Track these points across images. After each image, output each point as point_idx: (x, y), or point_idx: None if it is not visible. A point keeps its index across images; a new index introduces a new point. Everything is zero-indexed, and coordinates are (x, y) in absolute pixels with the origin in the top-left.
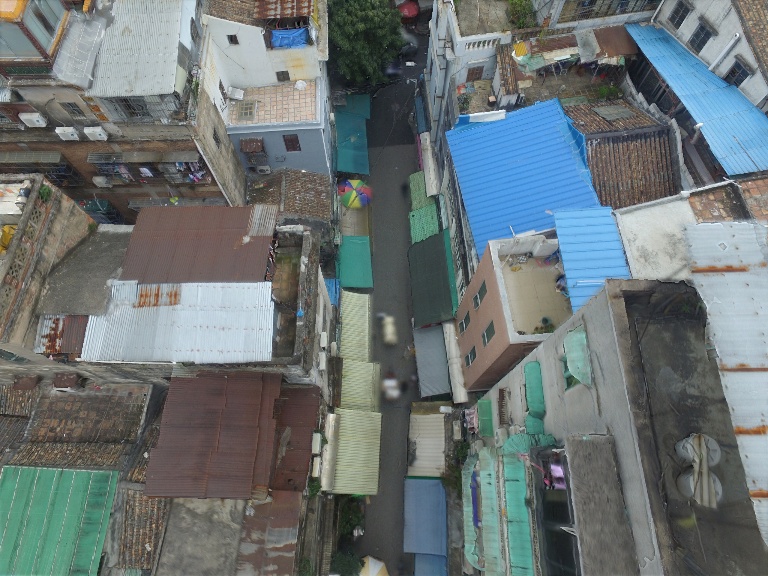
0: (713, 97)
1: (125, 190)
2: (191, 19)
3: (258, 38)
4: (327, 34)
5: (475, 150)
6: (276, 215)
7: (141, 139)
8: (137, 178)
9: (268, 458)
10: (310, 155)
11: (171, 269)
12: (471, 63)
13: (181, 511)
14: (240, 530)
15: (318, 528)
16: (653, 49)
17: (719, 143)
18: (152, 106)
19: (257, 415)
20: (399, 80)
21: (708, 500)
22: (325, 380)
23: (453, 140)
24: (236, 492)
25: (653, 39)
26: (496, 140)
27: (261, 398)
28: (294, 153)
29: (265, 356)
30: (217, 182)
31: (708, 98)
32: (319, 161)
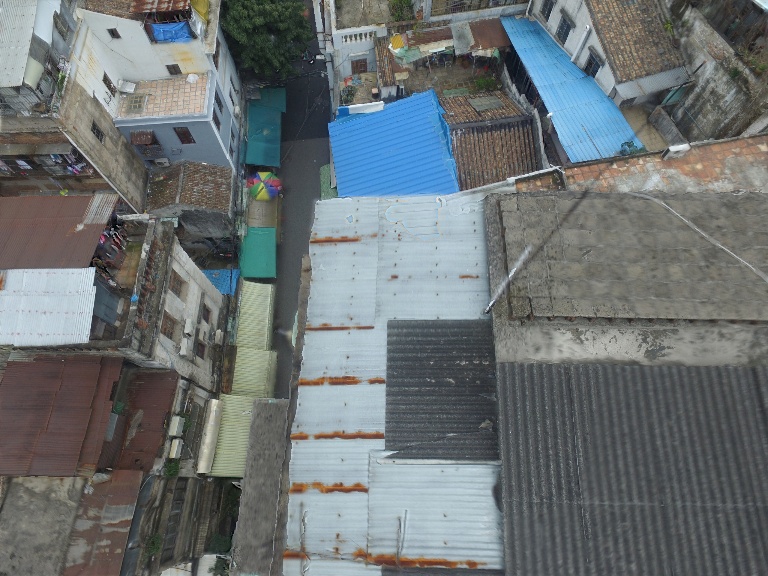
0: (569, 87)
1: (12, 183)
2: (54, 13)
3: (139, 32)
4: (217, 28)
5: (353, 141)
6: (115, 203)
7: (9, 131)
8: (17, 170)
9: (100, 438)
10: (206, 147)
11: (0, 256)
12: (352, 56)
13: (19, 490)
14: (77, 508)
15: (194, 510)
16: (523, 41)
17: (567, 132)
18: (8, 98)
19: (91, 397)
20: (312, 73)
21: None
22: (205, 366)
23: (334, 131)
24: (60, 470)
25: (525, 31)
26: (373, 131)
27: (99, 381)
28: (189, 145)
29: (83, 338)
30: (101, 174)
31: (564, 88)
32: (217, 153)
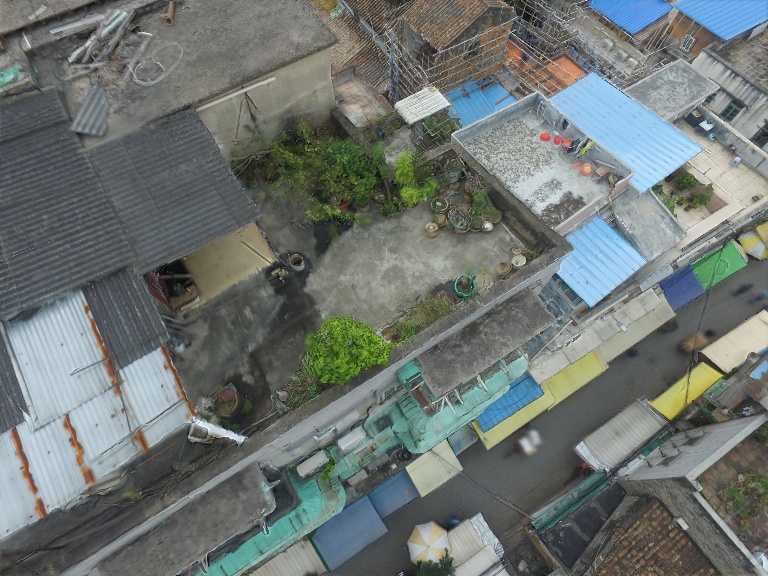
0: None
1: None
2: None
3: None
4: None
5: None
6: None
7: None
8: None
9: None
10: None
11: None
12: None
13: None
14: None
15: None
16: None
17: None
18: None
19: None
20: None
21: (113, 474)
22: None
23: None
24: None
25: None
26: None
27: None
28: None
29: None
30: None
31: None
32: None
